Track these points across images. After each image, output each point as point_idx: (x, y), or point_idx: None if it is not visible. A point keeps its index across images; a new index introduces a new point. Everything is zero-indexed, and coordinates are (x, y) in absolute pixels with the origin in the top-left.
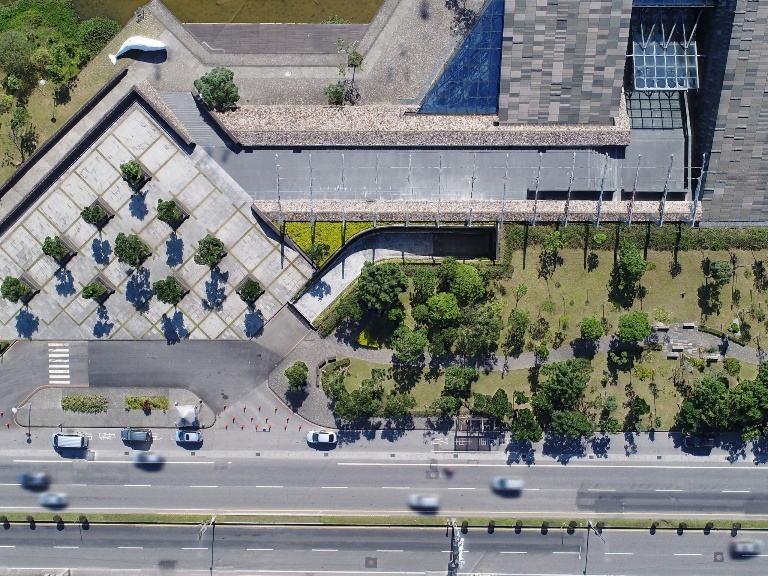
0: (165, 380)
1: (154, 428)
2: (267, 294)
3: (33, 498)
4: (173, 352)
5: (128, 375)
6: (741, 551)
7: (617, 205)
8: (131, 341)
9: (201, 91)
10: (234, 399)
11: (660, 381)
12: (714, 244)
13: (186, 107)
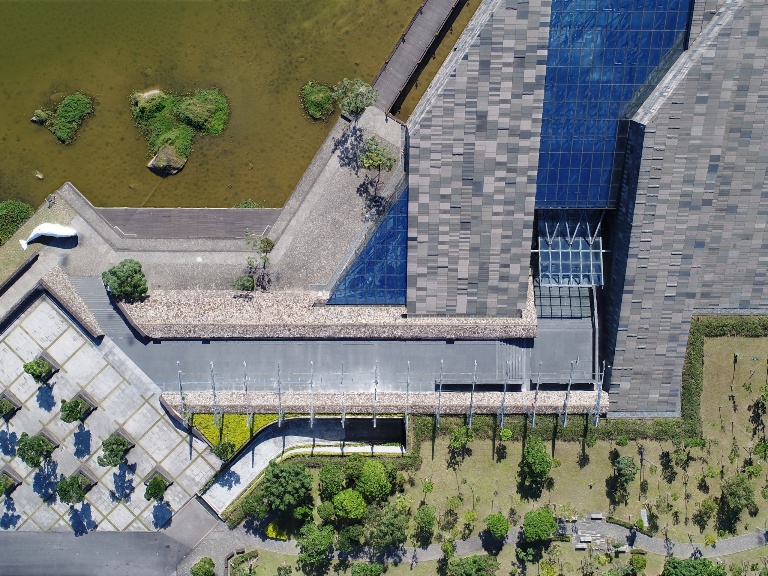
0: (72, 572)
1: None
2: (175, 485)
3: None
4: (81, 543)
5: (35, 567)
6: None
7: (524, 397)
8: (38, 533)
9: (109, 284)
10: None
11: None
12: (619, 440)
13: (96, 294)
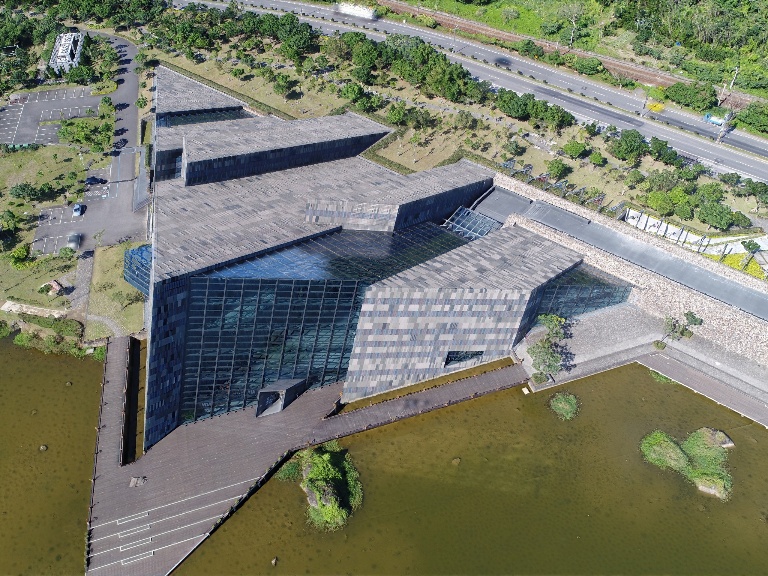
0: None
1: None
2: None
3: None
4: None
5: None
6: (572, 86)
7: (541, 196)
8: None
9: None
10: None
11: None
12: None
13: None
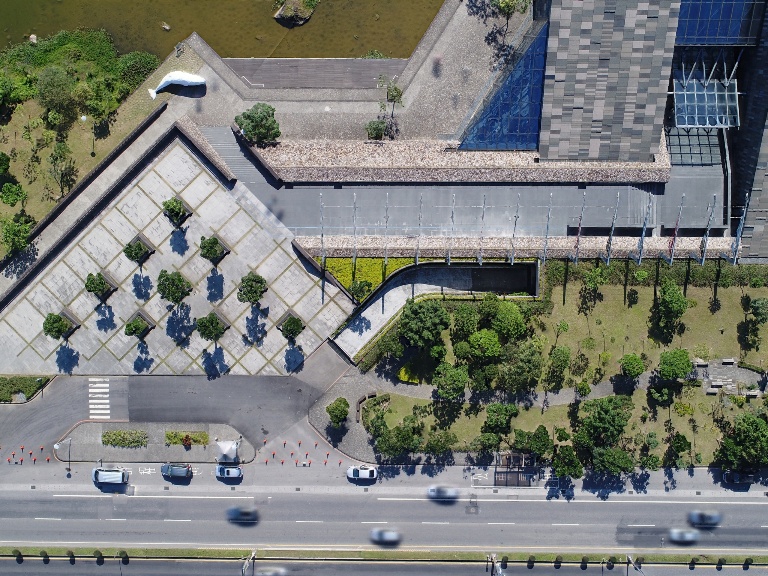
0: (205, 415)
1: (194, 463)
2: (307, 329)
3: (73, 533)
4: (213, 387)
5: (168, 410)
6: None
7: (657, 242)
8: (171, 376)
9: (242, 127)
10: (274, 434)
11: (699, 417)
12: (755, 281)
13: (226, 142)
